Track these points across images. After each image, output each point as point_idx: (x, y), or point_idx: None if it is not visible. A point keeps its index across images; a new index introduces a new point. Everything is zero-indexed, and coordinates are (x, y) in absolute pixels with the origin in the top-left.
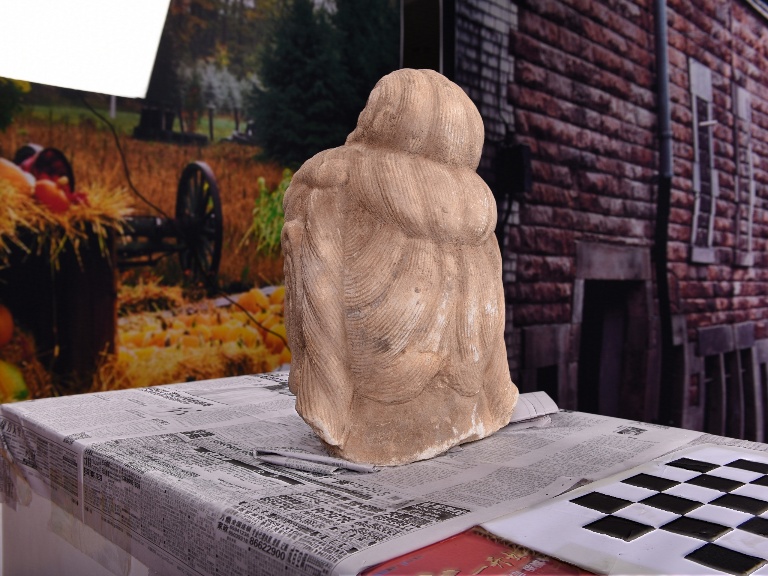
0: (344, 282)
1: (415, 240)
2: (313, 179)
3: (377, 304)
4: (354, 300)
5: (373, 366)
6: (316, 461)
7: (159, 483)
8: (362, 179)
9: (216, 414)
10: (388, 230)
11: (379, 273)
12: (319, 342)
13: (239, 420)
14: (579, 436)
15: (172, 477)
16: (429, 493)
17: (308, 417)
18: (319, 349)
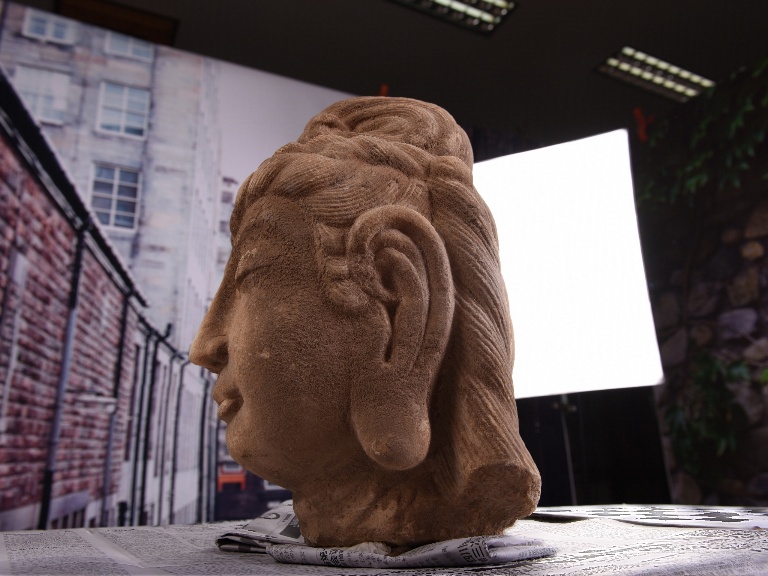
0: None
1: None
2: (416, 166)
3: None
4: None
5: None
6: None
7: None
8: None
9: None
10: None
11: None
12: None
13: (138, 570)
14: None
15: (640, 568)
16: (632, 539)
17: None
18: None
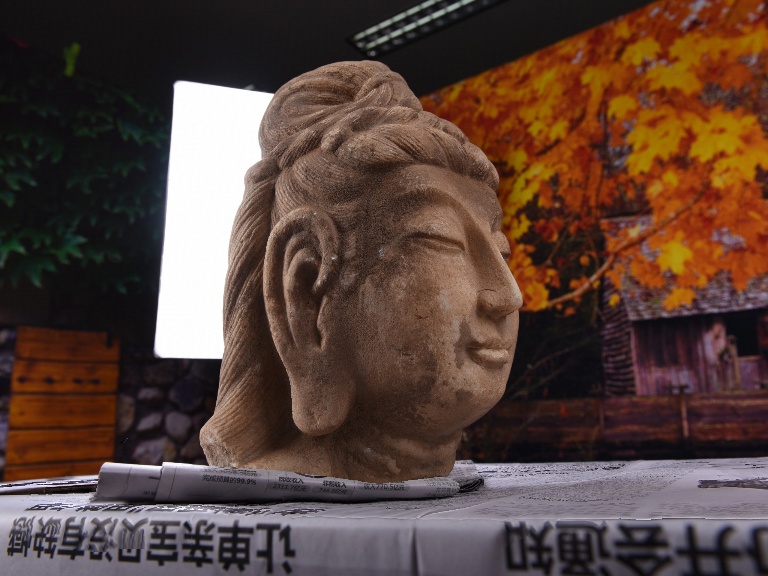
0: None
1: None
2: None
3: None
4: None
5: None
6: None
7: None
8: None
9: None
10: None
11: None
12: None
13: None
14: None
15: None
16: None
17: None
18: None
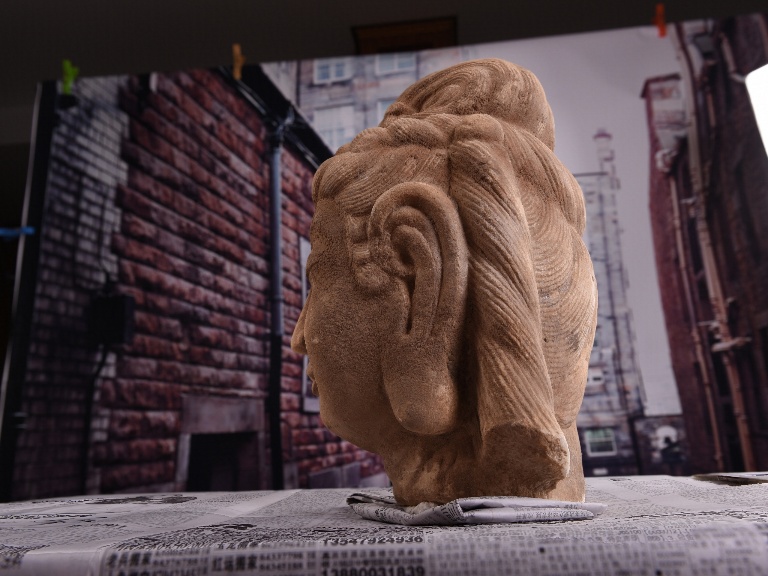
0: (533, 255)
1: (570, 225)
2: (437, 136)
3: (566, 288)
4: (546, 279)
5: (565, 369)
6: (546, 506)
7: (506, 539)
8: (523, 143)
9: (160, 514)
10: (556, 206)
11: (566, 250)
12: (532, 327)
13: (211, 518)
14: (601, 485)
15: (506, 528)
16: None
17: (551, 431)
18: (534, 336)
